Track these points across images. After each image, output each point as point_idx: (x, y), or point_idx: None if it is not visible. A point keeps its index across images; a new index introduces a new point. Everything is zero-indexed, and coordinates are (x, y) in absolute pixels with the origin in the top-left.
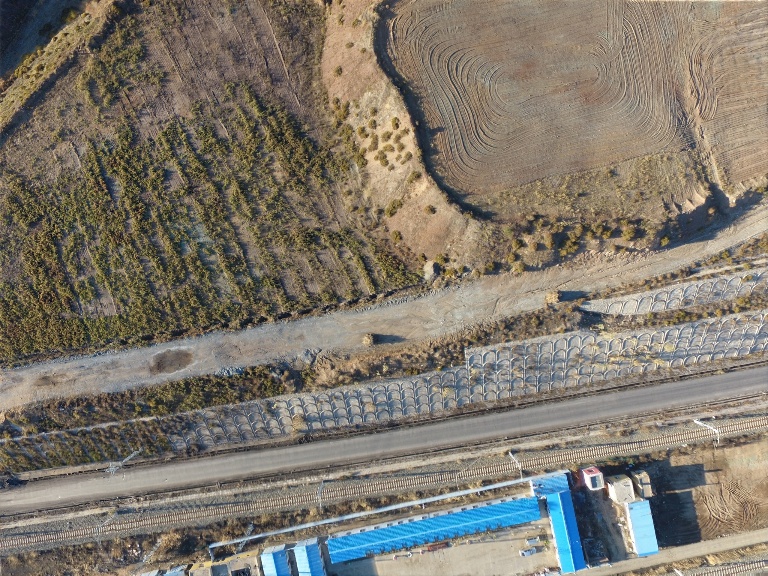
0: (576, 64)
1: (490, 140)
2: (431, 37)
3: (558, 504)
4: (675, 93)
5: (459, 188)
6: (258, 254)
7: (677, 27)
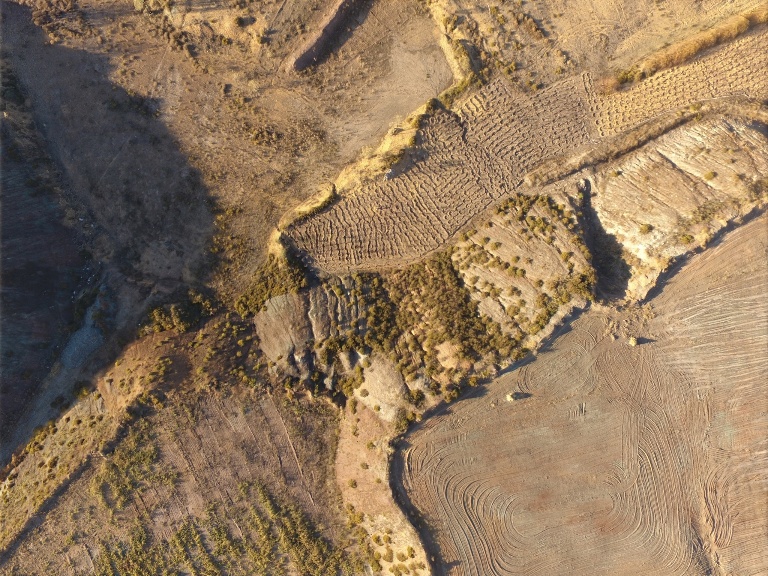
0: (591, 494)
1: (506, 573)
2: (446, 469)
3: None
4: (690, 520)
5: None
6: None
7: (692, 455)
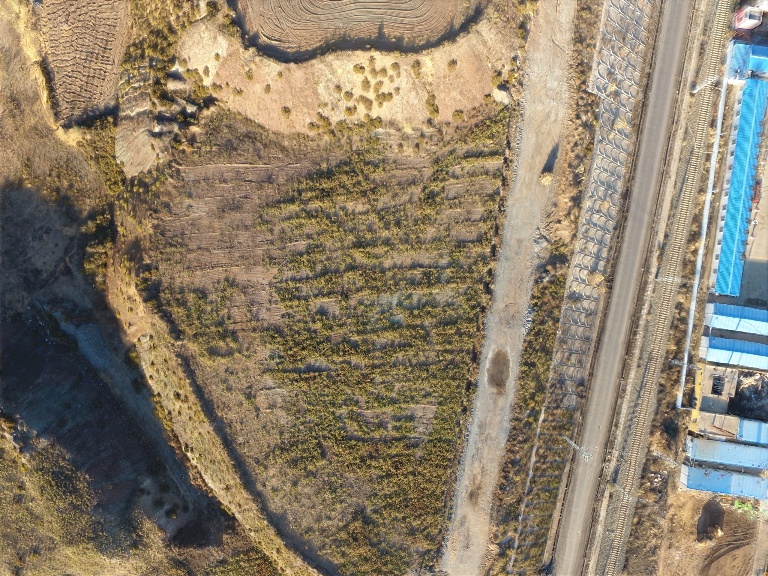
0: None
1: None
2: (290, 5)
3: (762, 60)
4: None
5: (443, 29)
6: (426, 254)
7: None
